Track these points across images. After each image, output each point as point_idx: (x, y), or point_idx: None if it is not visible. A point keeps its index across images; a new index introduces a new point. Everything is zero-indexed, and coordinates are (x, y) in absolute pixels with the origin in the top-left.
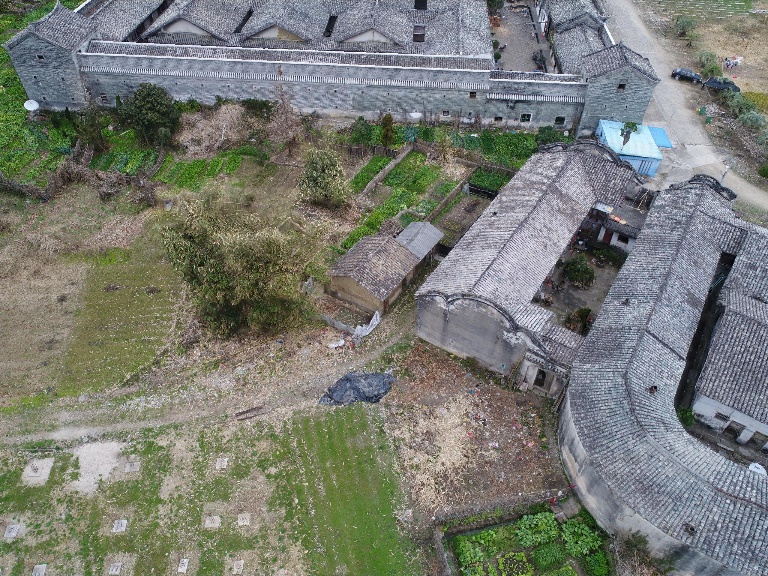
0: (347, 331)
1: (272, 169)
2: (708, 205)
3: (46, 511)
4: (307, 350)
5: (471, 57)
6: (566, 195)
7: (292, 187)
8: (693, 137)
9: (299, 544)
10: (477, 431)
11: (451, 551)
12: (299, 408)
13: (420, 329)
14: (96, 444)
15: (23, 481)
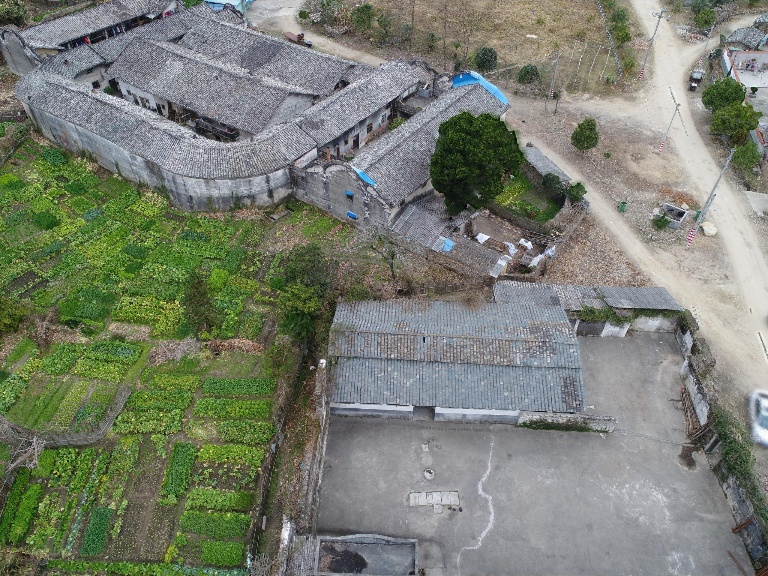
0: None
1: None
2: (200, 10)
3: None
4: None
5: None
6: (125, 6)
7: None
8: (293, 4)
9: None
10: (8, 101)
11: None
12: None
13: (9, 66)
14: None
15: None
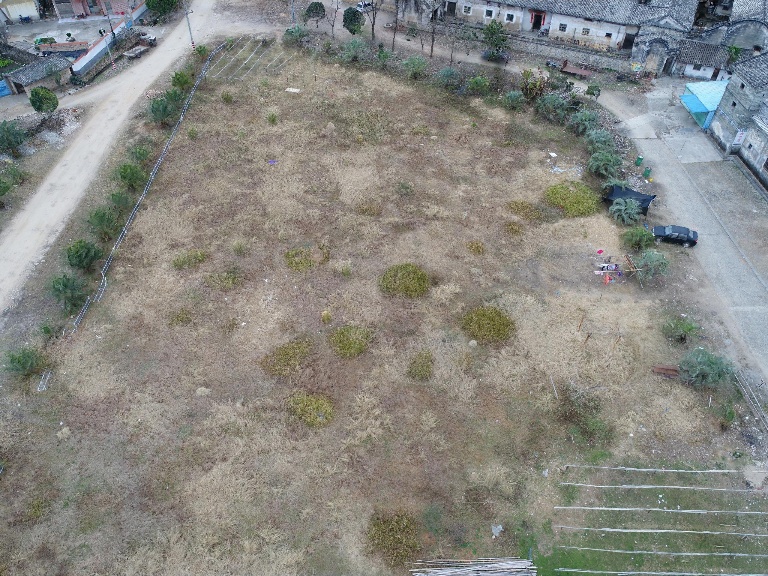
0: None
1: None
2: None
3: None
4: None
5: None
6: None
7: None
8: (651, 146)
9: None
10: None
11: None
12: None
13: None
14: None
15: None
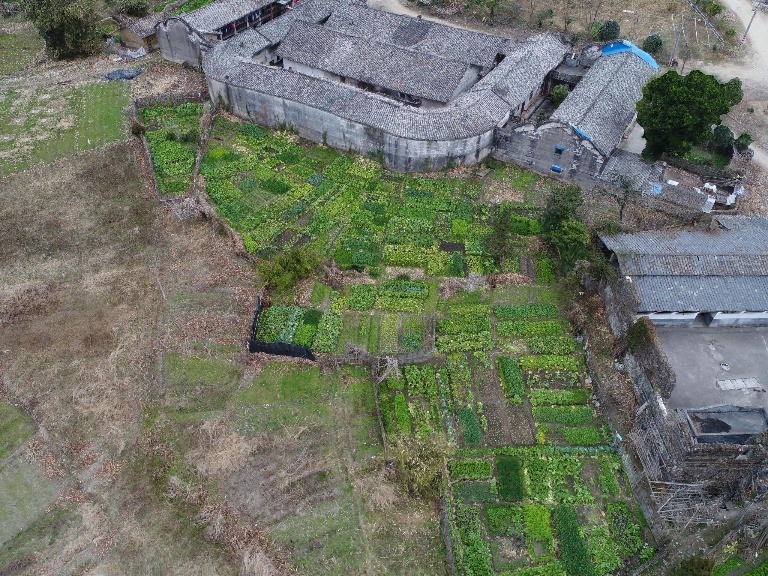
0: (124, 55)
1: (113, 4)
2: None
3: None
4: (101, 62)
5: None
6: None
7: None
8: None
9: (73, 114)
10: None
11: (143, 115)
12: (91, 82)
13: (162, 52)
14: None
15: None
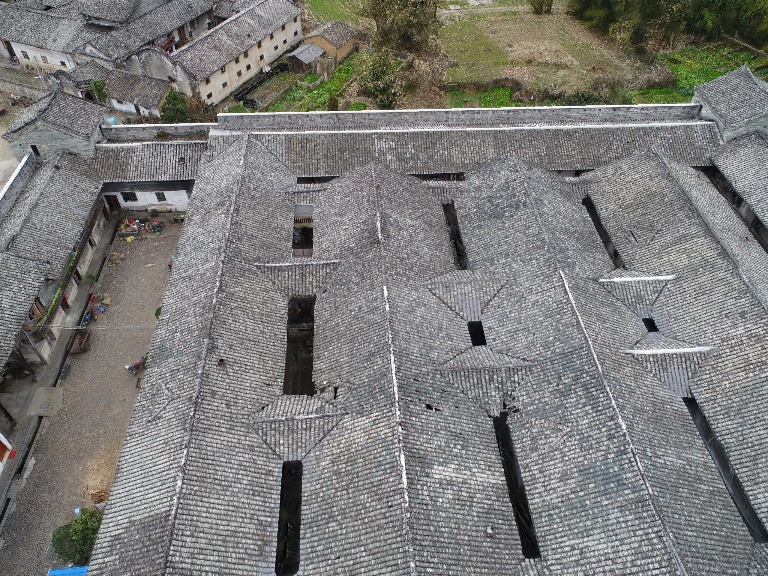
0: None
1: None
2: None
3: (441, 1)
4: None
5: (235, 133)
6: None
7: (412, 108)
8: None
9: None
10: None
11: None
12: None
13: None
14: (437, 10)
15: (457, 5)
